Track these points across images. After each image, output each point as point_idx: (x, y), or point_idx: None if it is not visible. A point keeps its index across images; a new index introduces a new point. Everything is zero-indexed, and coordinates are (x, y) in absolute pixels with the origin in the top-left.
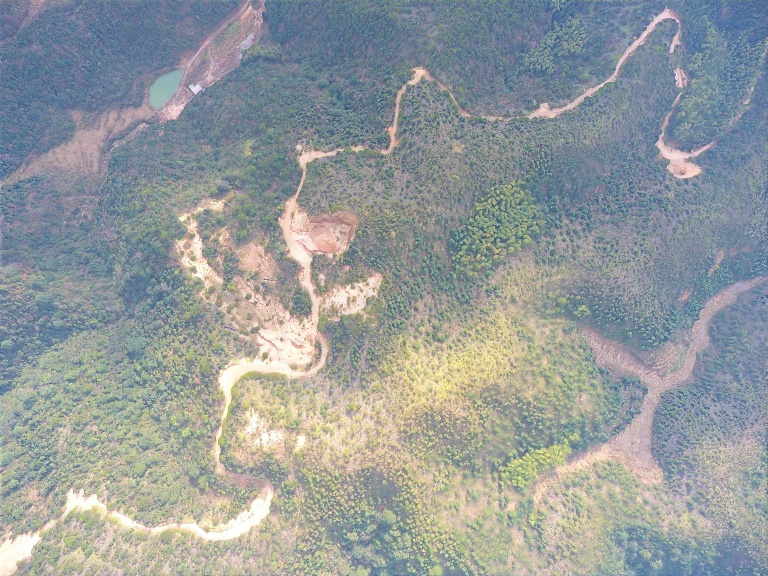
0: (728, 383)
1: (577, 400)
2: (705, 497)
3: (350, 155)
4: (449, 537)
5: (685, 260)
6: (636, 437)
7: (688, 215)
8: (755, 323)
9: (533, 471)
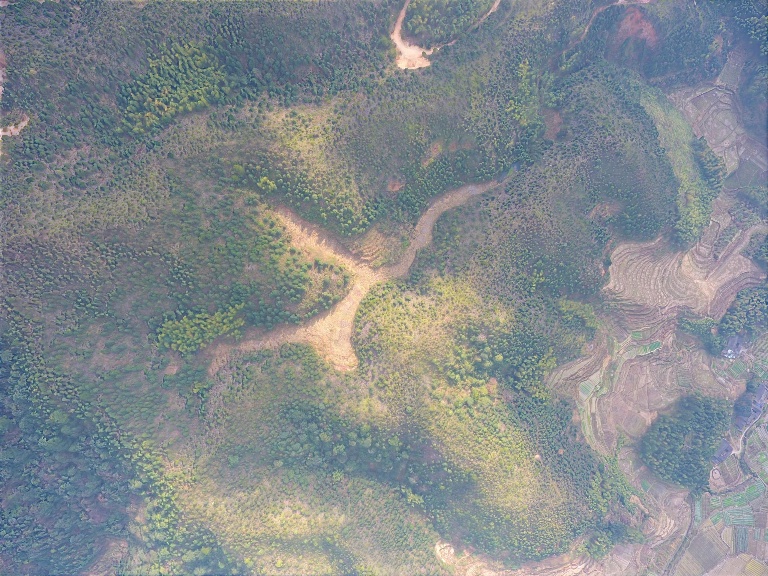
0: (433, 277)
1: (246, 269)
2: (384, 382)
3: (32, 5)
4: (69, 381)
5: (387, 145)
6: (337, 325)
7: (392, 99)
8: (473, 223)
9: (194, 336)
